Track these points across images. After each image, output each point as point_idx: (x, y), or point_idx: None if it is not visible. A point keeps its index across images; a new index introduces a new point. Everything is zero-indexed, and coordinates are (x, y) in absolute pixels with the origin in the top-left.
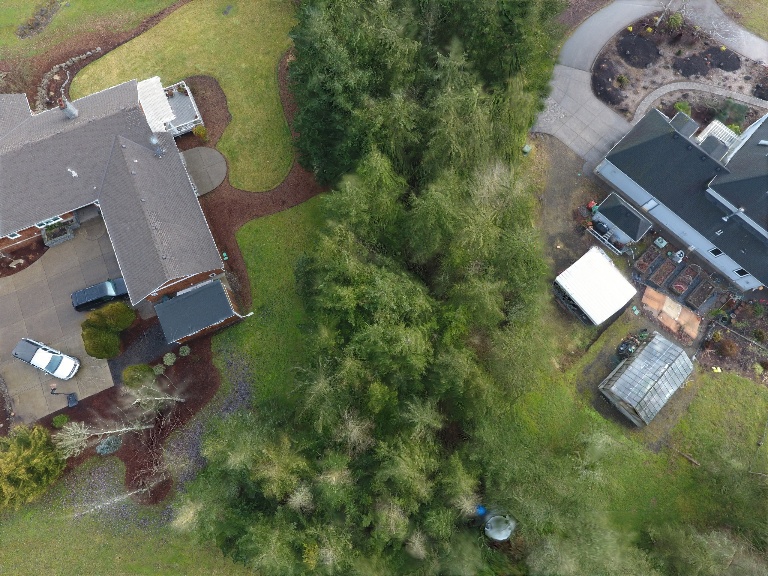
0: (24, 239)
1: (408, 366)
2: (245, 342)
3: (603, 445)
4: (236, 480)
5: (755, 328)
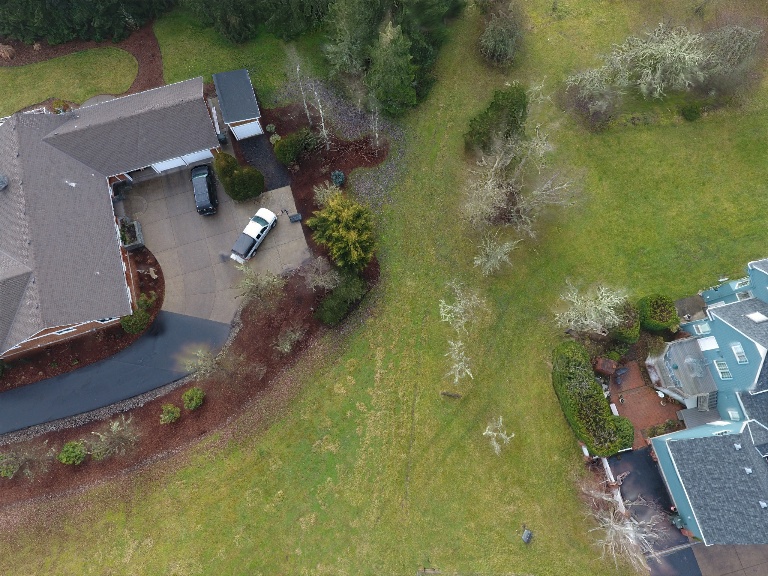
0: (129, 269)
1: None
2: (273, 84)
3: None
4: (369, 13)
5: None
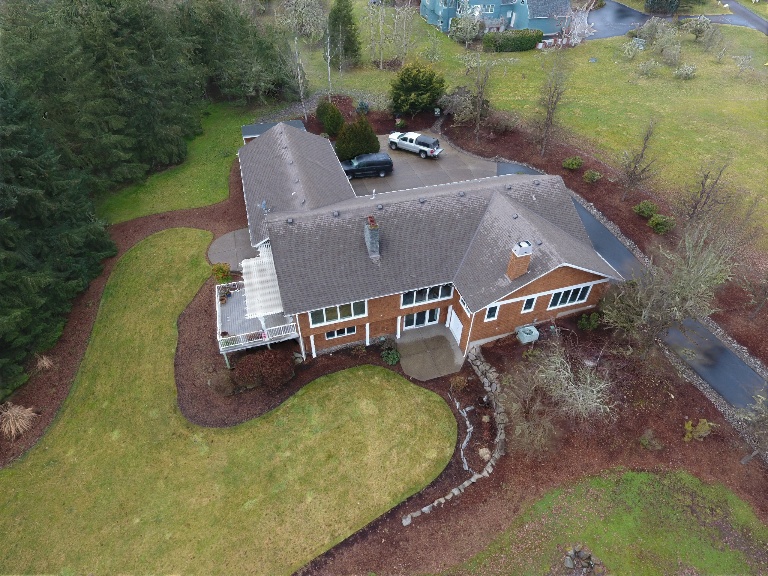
0: None
1: None
2: None
3: None
4: None
5: None
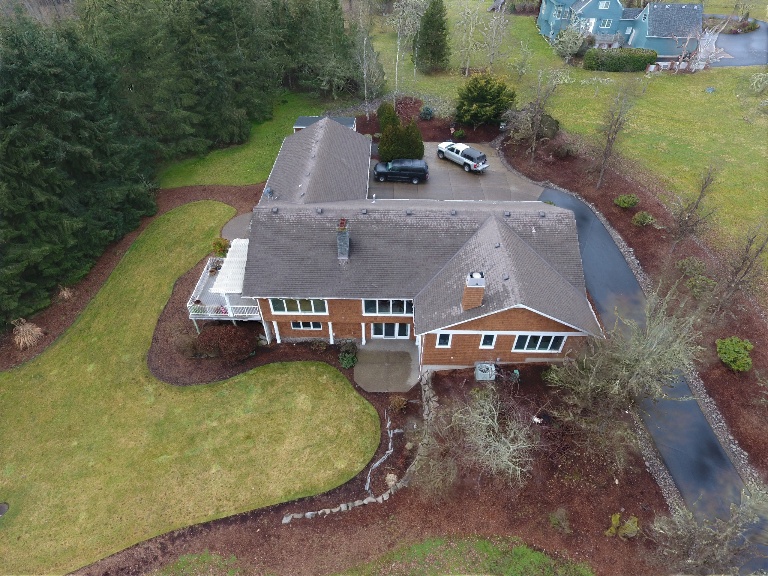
0: None
1: None
2: None
3: None
4: None
5: None
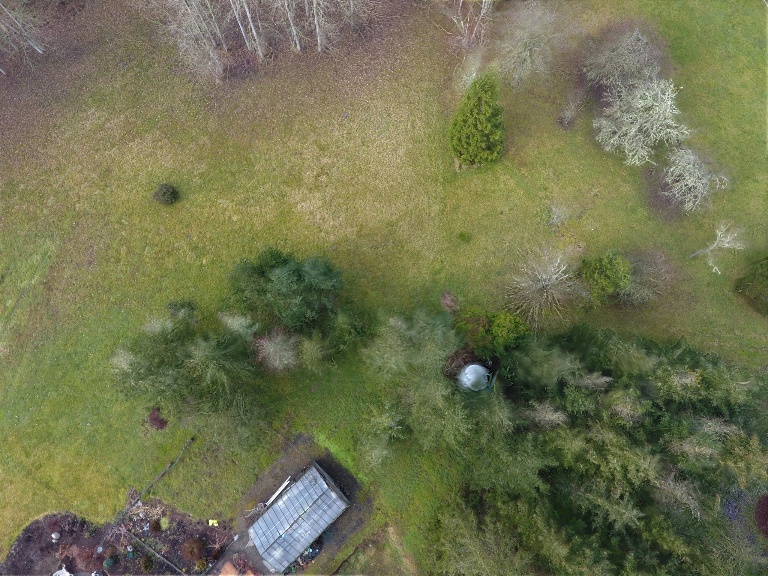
0: None
1: (646, 573)
2: None
3: (380, 454)
4: (766, 441)
5: (149, 573)
